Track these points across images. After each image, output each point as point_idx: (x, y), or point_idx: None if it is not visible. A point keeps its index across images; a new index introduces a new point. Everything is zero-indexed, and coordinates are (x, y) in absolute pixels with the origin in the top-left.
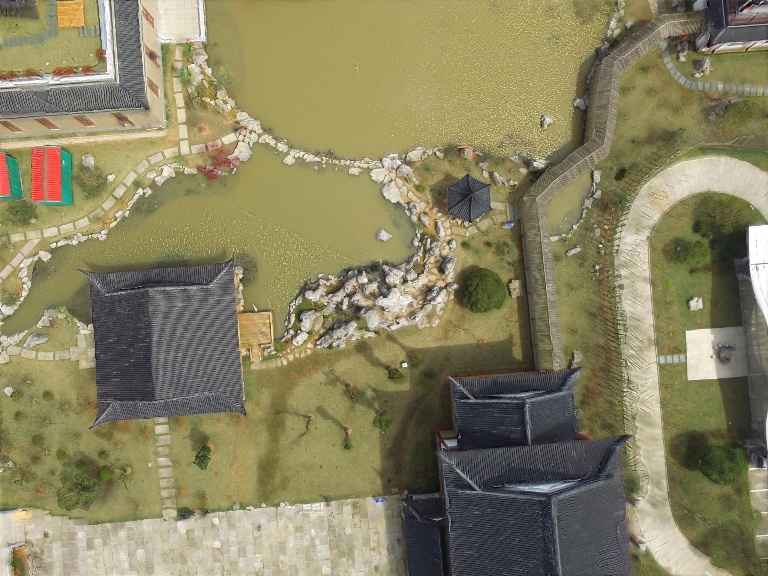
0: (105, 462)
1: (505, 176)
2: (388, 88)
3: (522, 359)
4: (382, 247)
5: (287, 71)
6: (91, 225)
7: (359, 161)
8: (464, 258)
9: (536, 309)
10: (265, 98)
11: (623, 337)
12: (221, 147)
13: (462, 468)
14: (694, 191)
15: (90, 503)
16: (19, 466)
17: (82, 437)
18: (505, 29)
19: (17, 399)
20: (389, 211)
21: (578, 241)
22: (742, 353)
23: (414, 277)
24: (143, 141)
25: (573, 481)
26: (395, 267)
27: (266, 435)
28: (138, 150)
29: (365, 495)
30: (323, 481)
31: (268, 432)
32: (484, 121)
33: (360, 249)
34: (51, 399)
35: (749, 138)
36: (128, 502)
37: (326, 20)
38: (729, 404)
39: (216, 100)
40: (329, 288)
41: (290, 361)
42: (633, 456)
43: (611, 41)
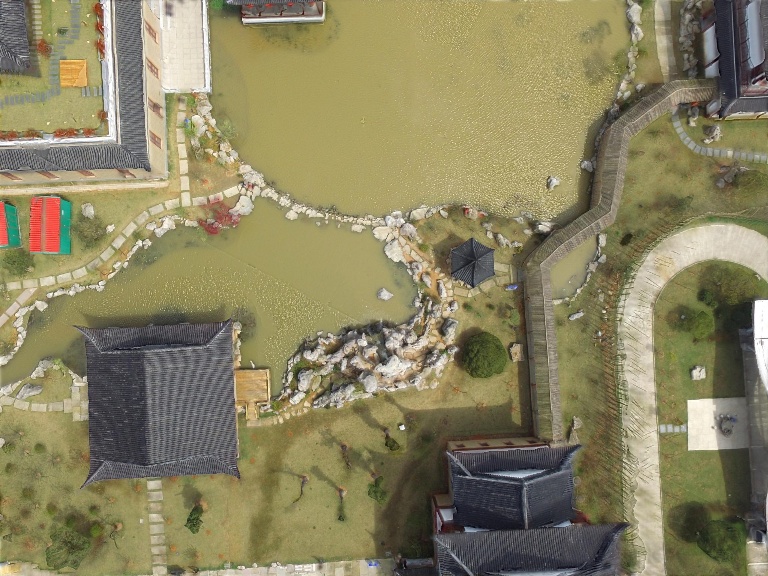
0: (96, 517)
1: (509, 237)
2: (394, 143)
3: (521, 424)
4: (383, 306)
5: (292, 122)
6: (89, 275)
7: (362, 218)
8: (465, 320)
9: (537, 377)
10: (269, 149)
11: (624, 407)
12: (223, 200)
13: (457, 552)
14: (700, 258)
15: (79, 562)
16: (9, 519)
17: (73, 491)
18: (514, 87)
19: (9, 451)
20: (391, 270)
21: (581, 305)
22: (744, 424)
23: (414, 339)
24: (144, 191)
25: (569, 572)
26: (395, 327)
27: (260, 494)
28: (139, 200)
29: (358, 557)
30: (316, 542)
31: (262, 491)
32: (490, 180)
33: (360, 307)
34: (43, 451)
35: (758, 210)
36: (118, 558)
37: (333, 72)
38: (729, 476)
39: (219, 152)
40: (328, 347)
41: (286, 419)
42: (631, 531)
43: (621, 103)
